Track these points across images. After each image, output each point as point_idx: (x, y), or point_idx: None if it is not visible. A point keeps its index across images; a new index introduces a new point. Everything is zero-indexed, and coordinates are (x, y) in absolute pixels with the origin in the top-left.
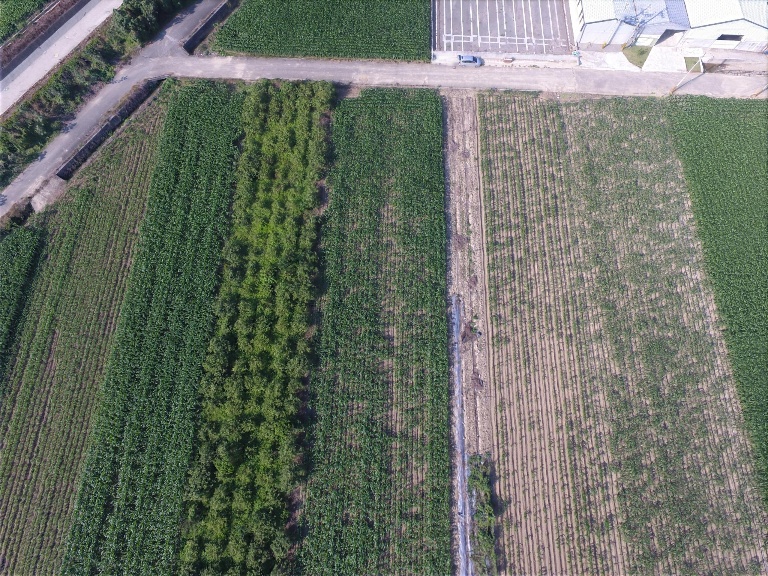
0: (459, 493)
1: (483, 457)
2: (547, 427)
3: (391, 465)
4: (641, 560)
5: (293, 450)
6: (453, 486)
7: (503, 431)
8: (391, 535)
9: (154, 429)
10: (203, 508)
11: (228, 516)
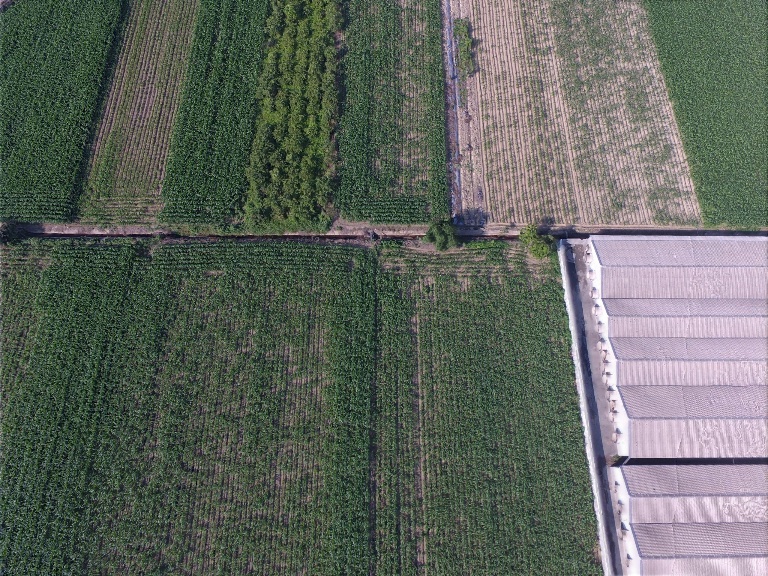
0: (448, 37)
1: (463, 20)
2: (507, 5)
3: (401, 23)
4: (568, 63)
5: (335, 7)
6: (443, 34)
7: (477, 8)
8: (403, 53)
9: (241, 1)
10: (277, 40)
11: (294, 42)
